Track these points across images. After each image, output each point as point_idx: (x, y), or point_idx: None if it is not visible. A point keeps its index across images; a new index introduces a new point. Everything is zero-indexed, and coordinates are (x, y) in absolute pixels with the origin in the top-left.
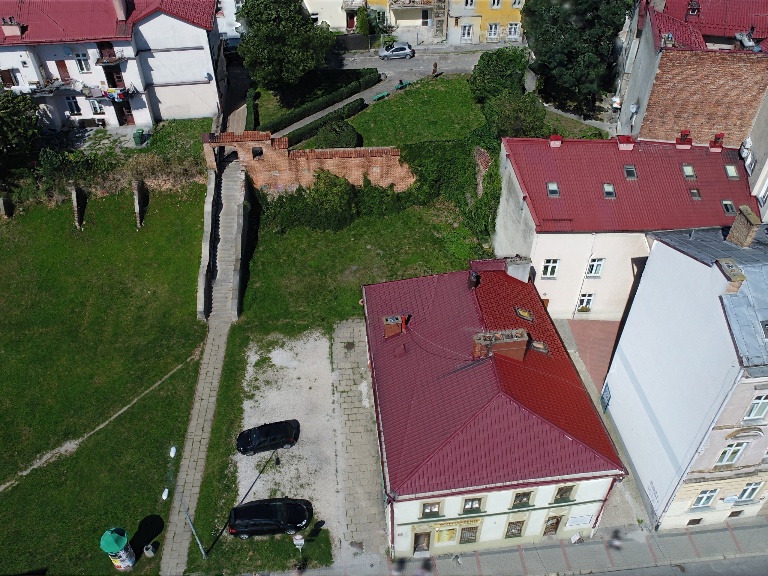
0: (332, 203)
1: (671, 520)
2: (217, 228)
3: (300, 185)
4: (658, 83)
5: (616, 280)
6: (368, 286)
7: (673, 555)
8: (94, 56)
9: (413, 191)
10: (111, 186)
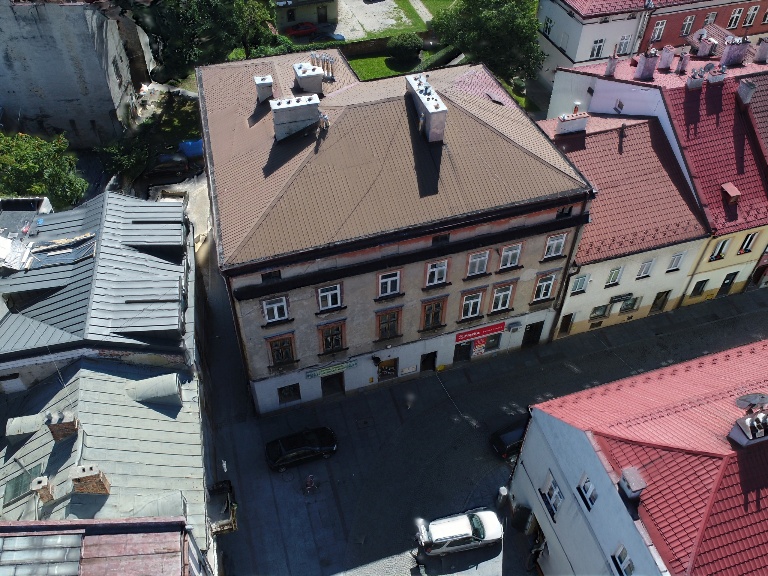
0: None
1: None
2: None
3: None
4: None
5: None
6: None
7: None
8: None
9: None
10: None
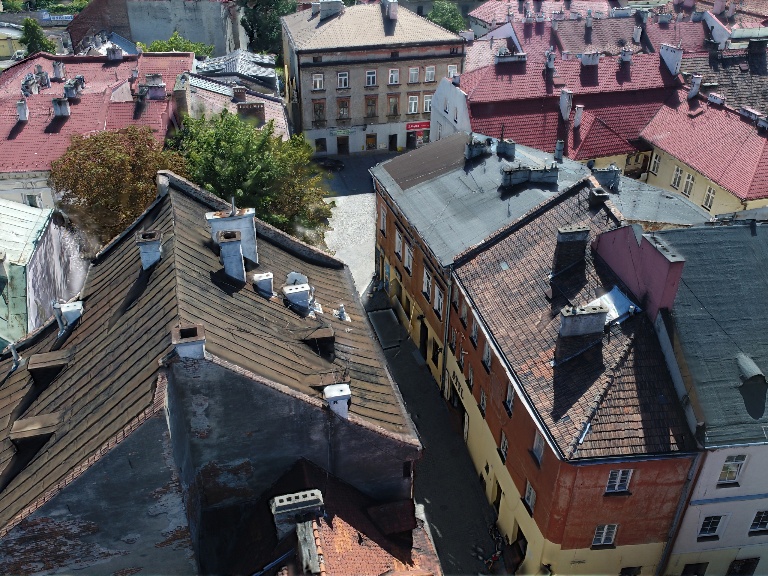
0: None
1: None
2: None
3: None
4: None
5: None
6: None
7: None
8: None
9: None
10: None
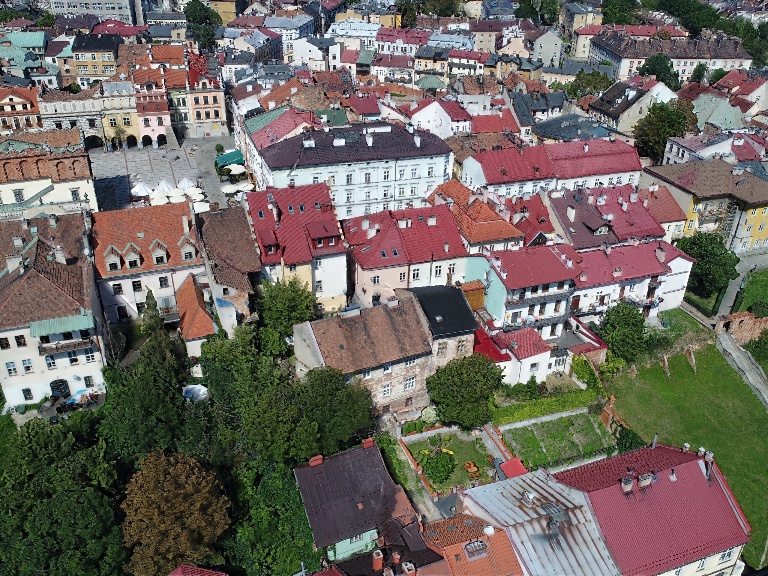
0: None
1: None
2: None
3: (752, 338)
4: None
5: None
6: None
7: None
8: (647, 282)
9: None
10: (673, 351)
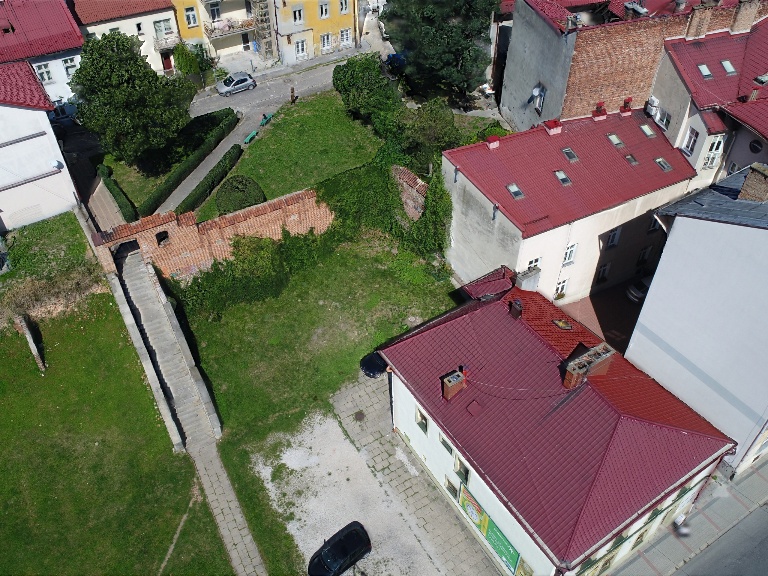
0: (264, 269)
1: (743, 466)
2: (146, 339)
3: (215, 259)
4: (575, 64)
5: (586, 260)
6: (387, 349)
7: (757, 496)
8: None
9: (337, 229)
10: None
